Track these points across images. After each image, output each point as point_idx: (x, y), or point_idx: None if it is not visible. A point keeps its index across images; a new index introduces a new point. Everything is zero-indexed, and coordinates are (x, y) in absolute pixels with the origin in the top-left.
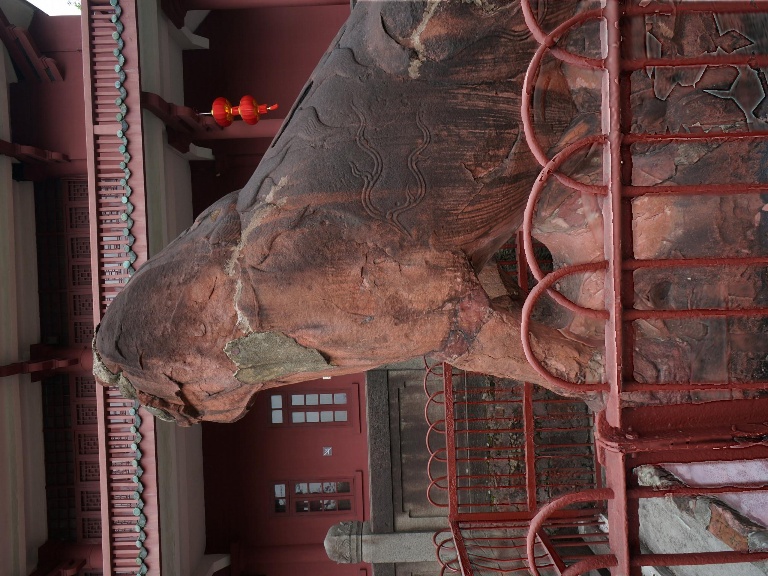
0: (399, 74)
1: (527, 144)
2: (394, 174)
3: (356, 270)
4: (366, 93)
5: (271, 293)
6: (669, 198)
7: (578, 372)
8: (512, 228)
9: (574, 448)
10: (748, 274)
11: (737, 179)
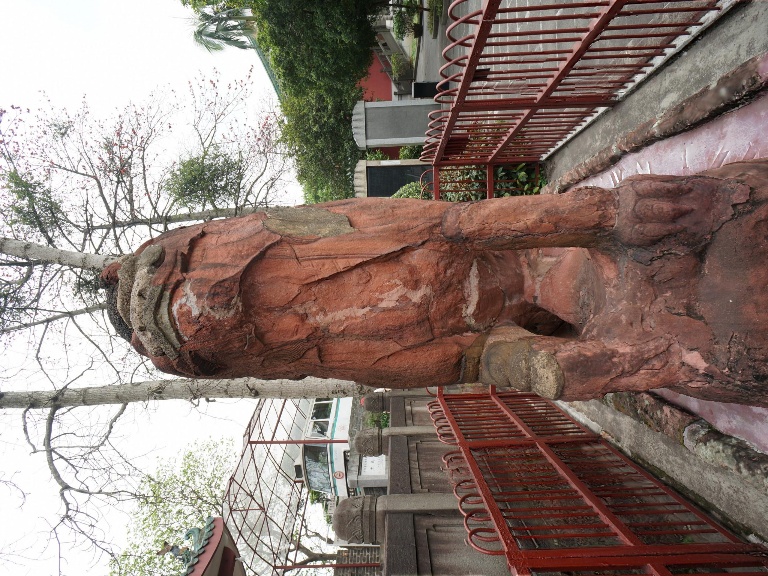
0: None
1: None
2: None
3: None
4: None
5: None
6: None
7: None
8: (512, 266)
9: None
10: None
11: None
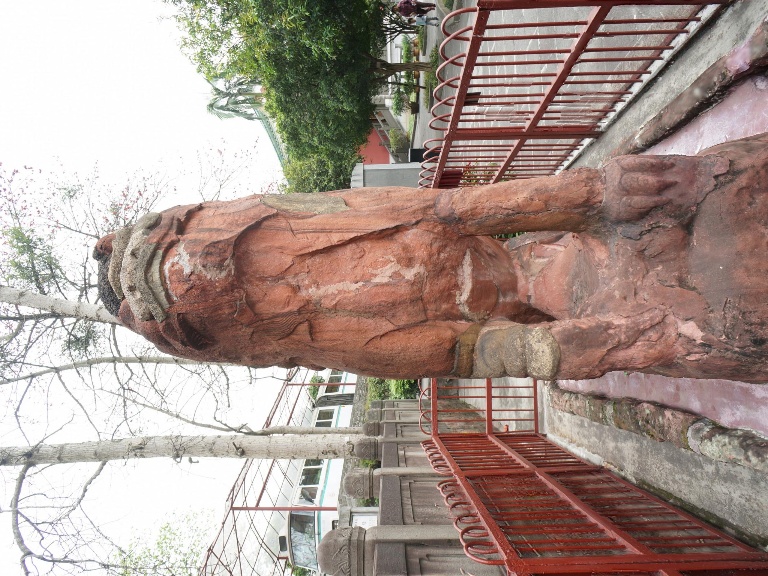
0: None
1: None
2: None
3: None
4: None
5: None
6: None
7: None
8: (505, 265)
9: None
10: None
11: None
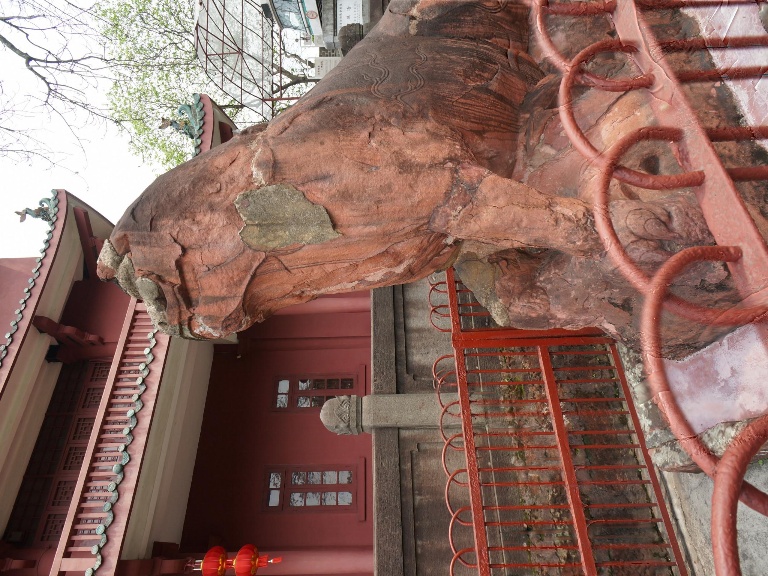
0: (402, 34)
1: (507, 79)
2: (398, 76)
3: (364, 134)
4: (377, 46)
5: (287, 150)
6: (635, 102)
7: (585, 212)
8: (506, 158)
9: (637, 530)
10: (723, 126)
11: (685, 73)
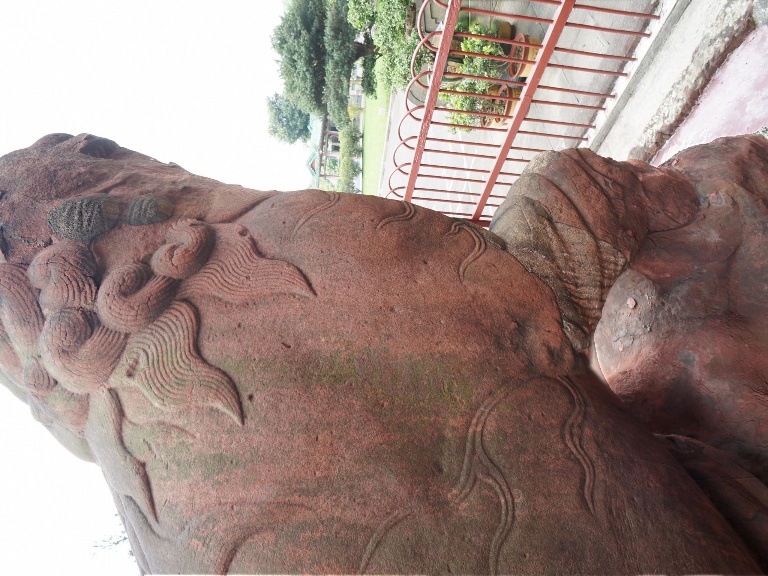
0: None
1: None
2: None
3: None
4: None
5: None
6: None
7: None
8: None
9: None
10: None
11: None
